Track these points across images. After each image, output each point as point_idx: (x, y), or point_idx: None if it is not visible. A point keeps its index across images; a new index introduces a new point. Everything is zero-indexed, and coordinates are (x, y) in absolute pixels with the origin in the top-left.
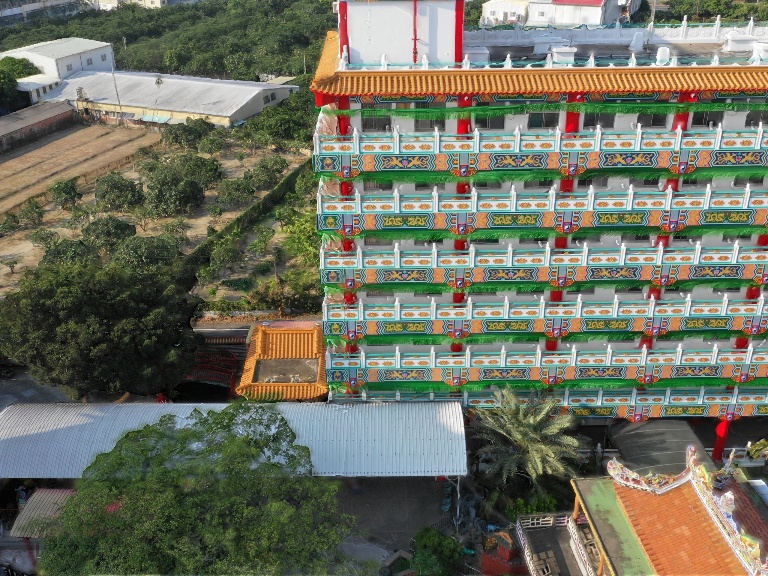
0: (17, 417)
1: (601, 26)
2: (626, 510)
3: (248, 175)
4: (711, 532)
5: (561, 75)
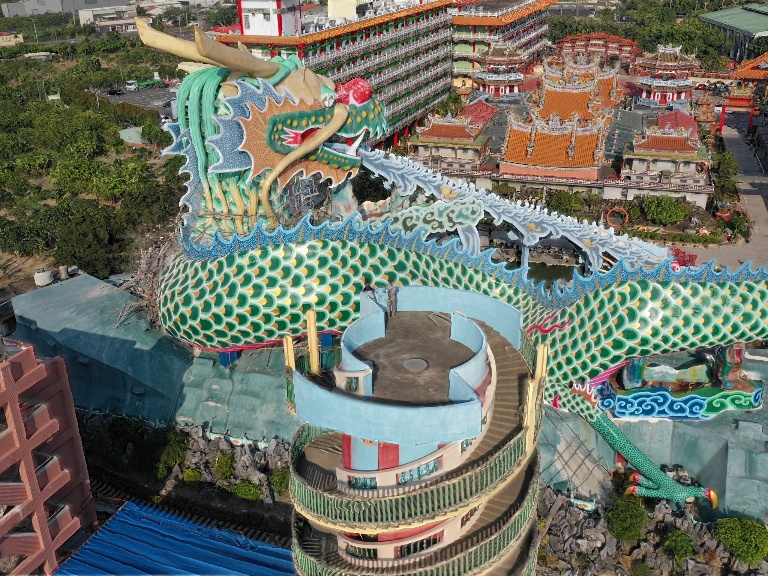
0: None
1: None
2: (429, 135)
3: None
4: (449, 126)
5: (335, 30)
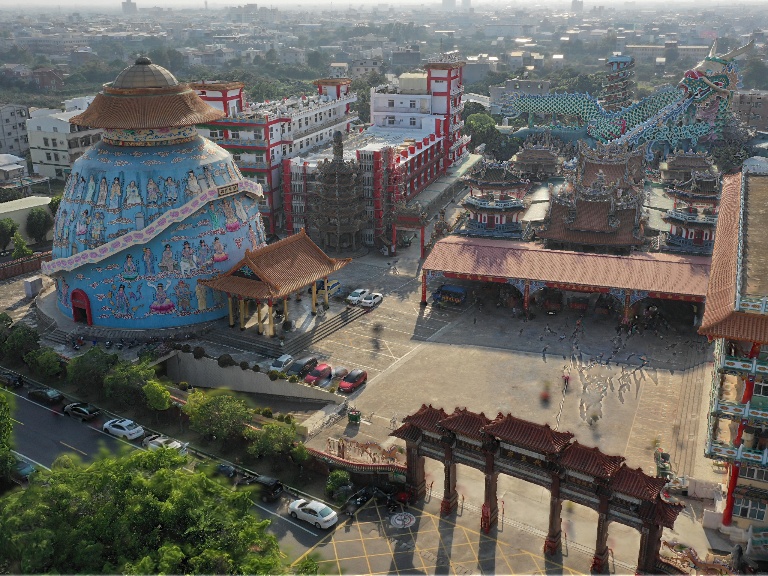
0: (761, 157)
1: None
2: None
3: None
4: None
5: None
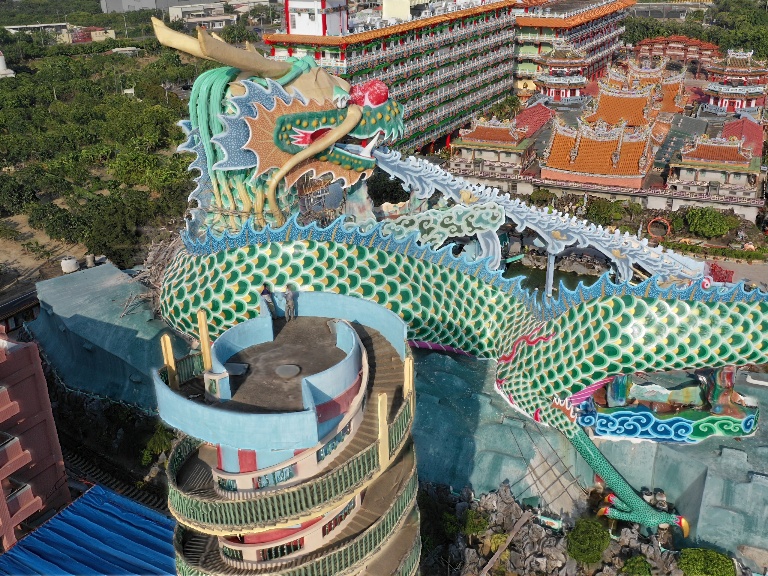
0: None
1: (10, 69)
2: (472, 138)
3: (31, 180)
4: (493, 129)
5: None
